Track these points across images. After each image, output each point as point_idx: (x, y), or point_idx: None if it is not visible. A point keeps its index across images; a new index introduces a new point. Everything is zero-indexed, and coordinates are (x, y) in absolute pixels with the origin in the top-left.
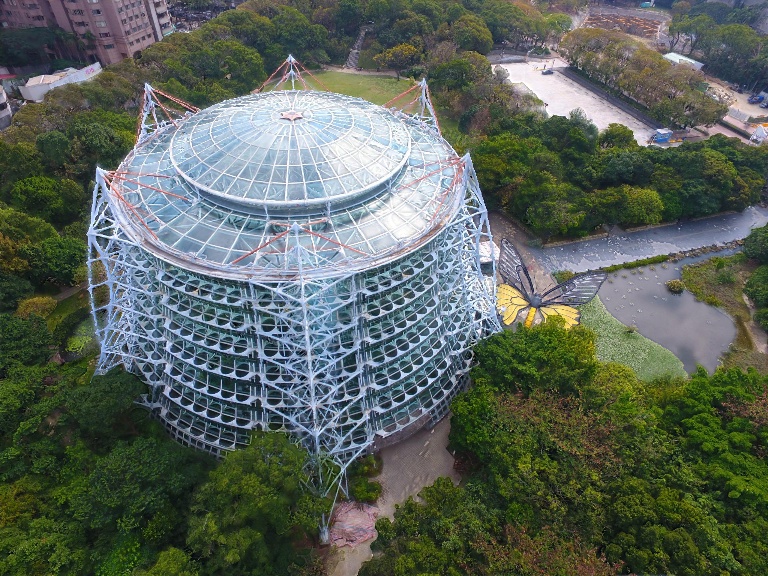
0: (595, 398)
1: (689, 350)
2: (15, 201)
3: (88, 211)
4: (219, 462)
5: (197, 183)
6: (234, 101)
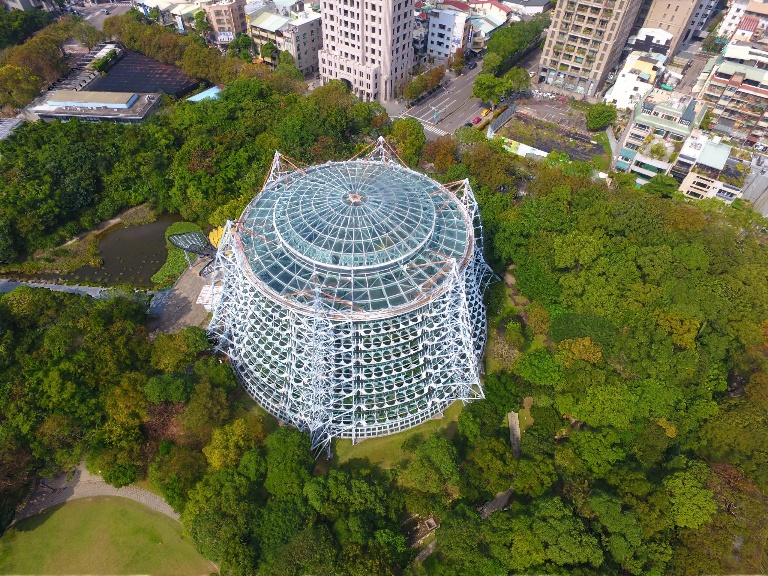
0: (266, 180)
1: (154, 232)
2: None
3: None
4: None
5: None
6: (387, 248)
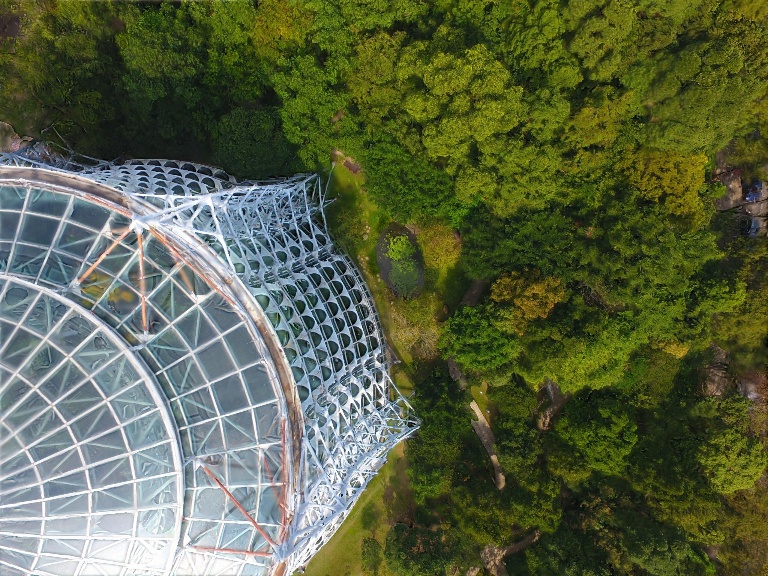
0: None
1: None
2: (609, 403)
3: (528, 442)
4: (154, 148)
5: (35, 288)
6: None
